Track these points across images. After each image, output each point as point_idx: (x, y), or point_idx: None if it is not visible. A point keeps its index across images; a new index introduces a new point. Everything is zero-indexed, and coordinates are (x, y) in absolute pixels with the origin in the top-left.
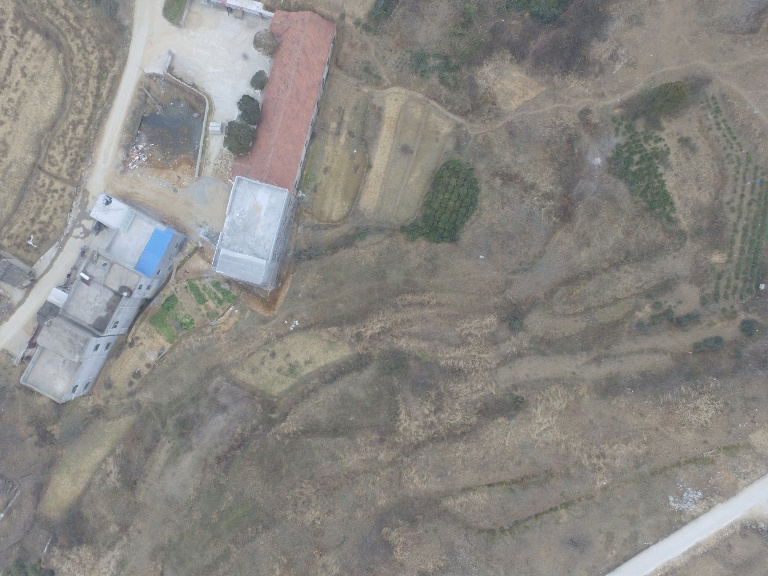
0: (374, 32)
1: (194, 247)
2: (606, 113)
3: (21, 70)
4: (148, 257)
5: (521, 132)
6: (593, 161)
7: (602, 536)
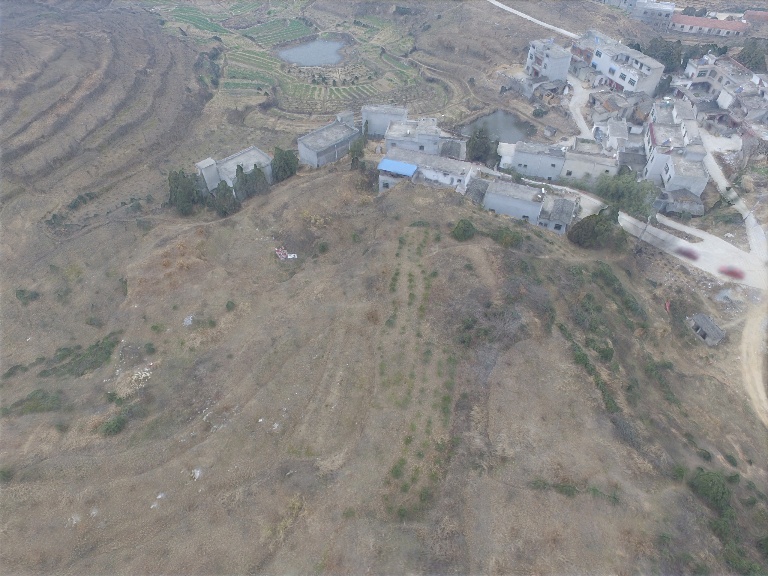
0: None
1: None
2: None
3: (696, 5)
4: None
5: None
6: None
7: (563, 22)
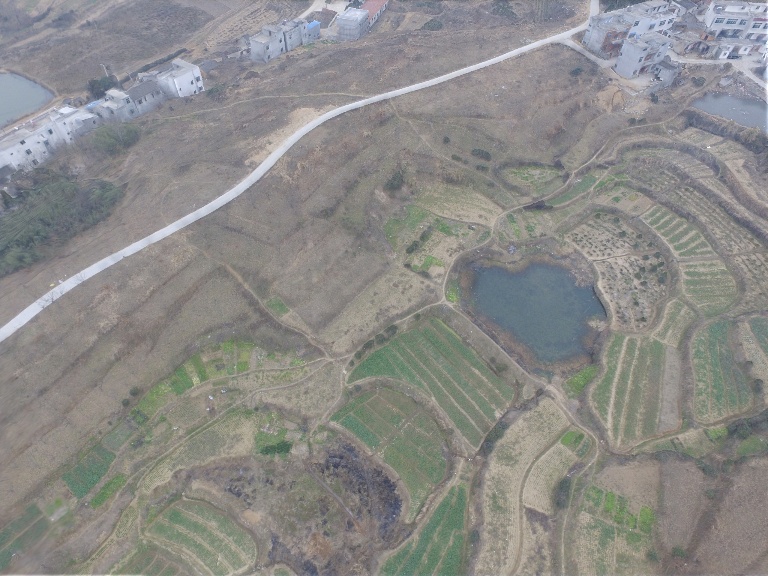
0: (403, 2)
1: (324, 40)
2: (488, 3)
3: None
4: (309, 25)
5: (458, 12)
6: (485, 13)
7: None
